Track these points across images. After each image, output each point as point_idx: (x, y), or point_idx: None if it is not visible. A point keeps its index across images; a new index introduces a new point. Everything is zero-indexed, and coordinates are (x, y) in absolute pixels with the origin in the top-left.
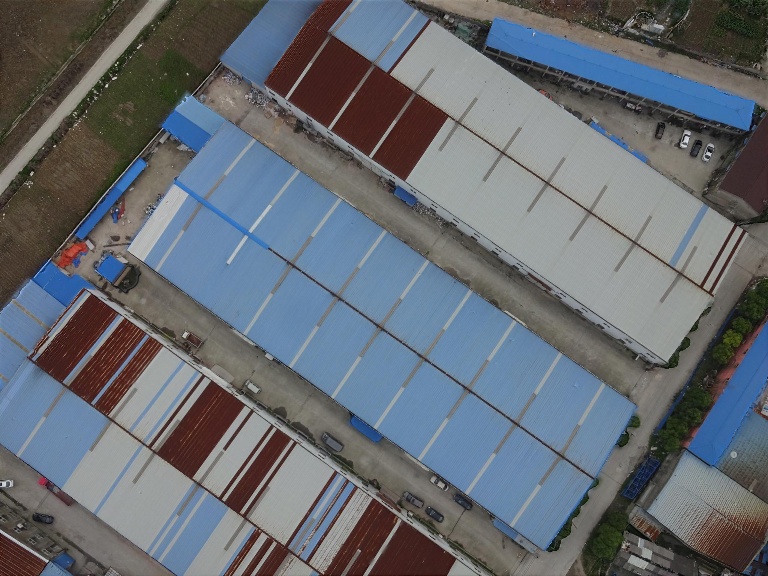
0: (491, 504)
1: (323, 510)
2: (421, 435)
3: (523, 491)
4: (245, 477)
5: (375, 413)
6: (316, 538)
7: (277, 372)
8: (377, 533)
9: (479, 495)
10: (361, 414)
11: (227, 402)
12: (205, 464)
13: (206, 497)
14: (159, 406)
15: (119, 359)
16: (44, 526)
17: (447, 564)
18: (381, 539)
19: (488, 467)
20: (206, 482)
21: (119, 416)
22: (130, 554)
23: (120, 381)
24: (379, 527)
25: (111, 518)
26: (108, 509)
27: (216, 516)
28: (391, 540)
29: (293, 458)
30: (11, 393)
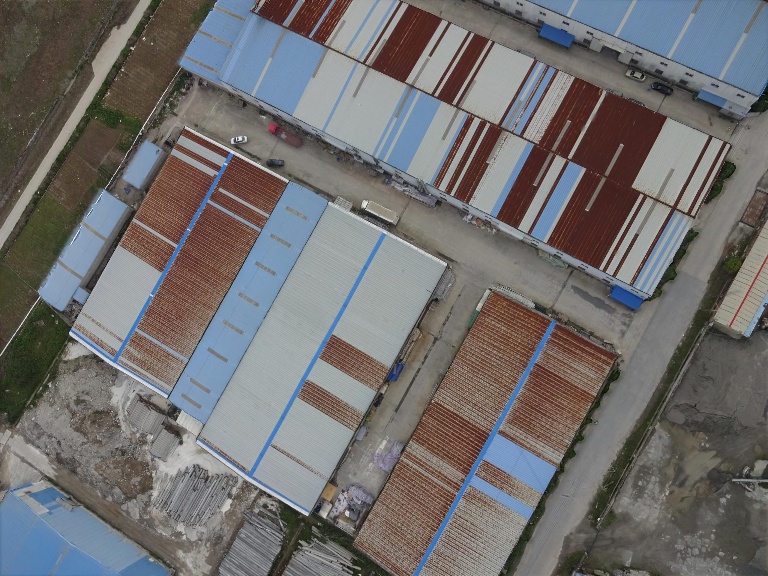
0: (696, 62)
1: (529, 92)
2: (615, 13)
3: (728, 43)
4: (452, 75)
5: (566, 2)
6: (526, 115)
7: (463, 9)
8: (584, 105)
9: (682, 56)
10: (552, 6)
11: (426, 19)
12: (414, 70)
13: (419, 96)
14: (366, 31)
15: (326, 0)
16: (277, 170)
17: (659, 122)
18: (589, 109)
19: (688, 27)
20: (418, 84)
21: (334, 43)
22: (353, 182)
23: (330, 17)
24: (585, 100)
25: (338, 132)
26: (334, 124)
27: (431, 111)
28: (599, 109)
29: (493, 55)
30: (241, 44)
